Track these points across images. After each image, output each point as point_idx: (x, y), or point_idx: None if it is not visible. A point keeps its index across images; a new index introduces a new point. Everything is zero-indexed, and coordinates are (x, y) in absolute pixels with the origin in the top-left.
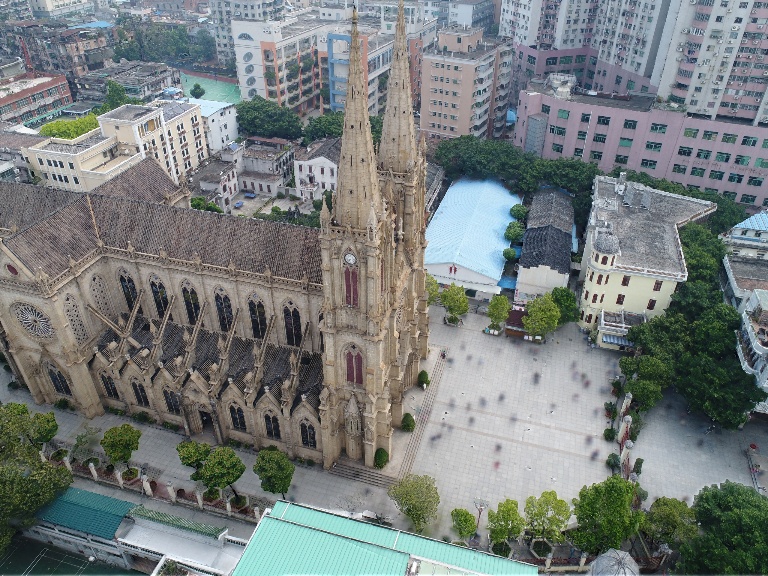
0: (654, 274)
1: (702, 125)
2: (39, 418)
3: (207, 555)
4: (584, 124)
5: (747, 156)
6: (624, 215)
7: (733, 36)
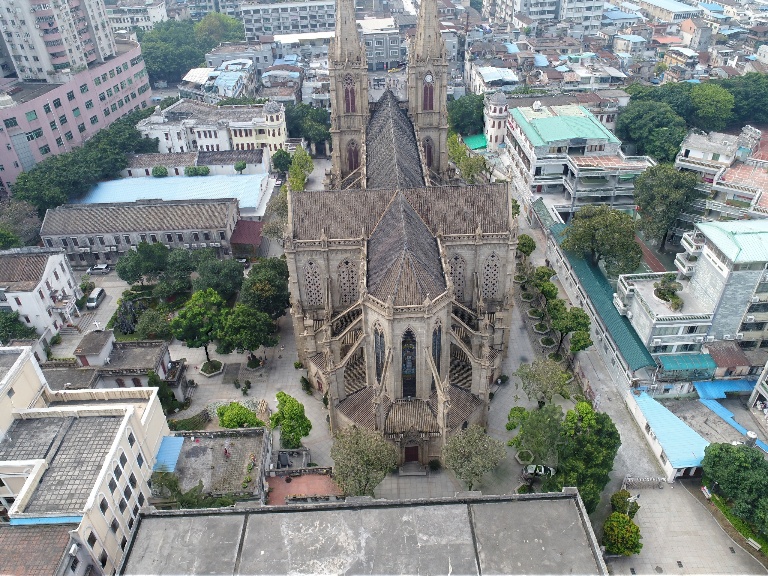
0: (281, 112)
1: (99, 72)
2: (543, 273)
3: None
4: (49, 115)
5: (123, 81)
6: (202, 120)
7: (63, 2)
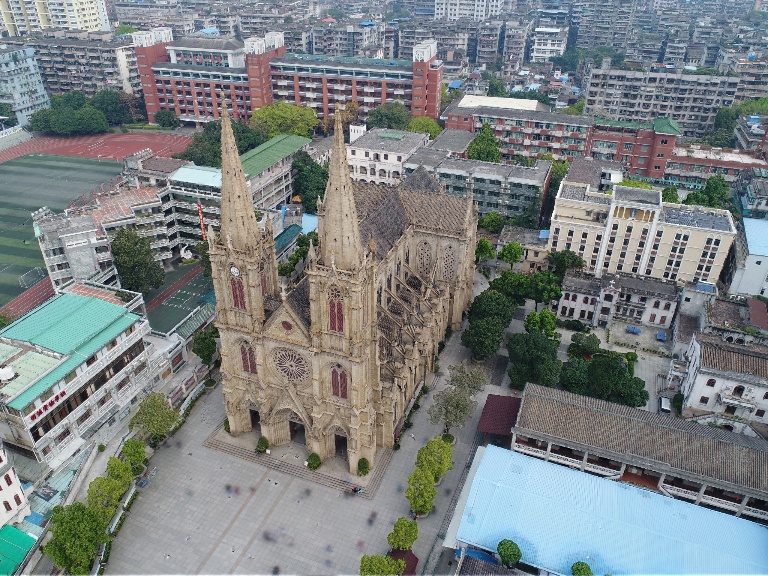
0: None
1: None
2: None
3: (177, 338)
4: None
5: None
6: None
7: None
